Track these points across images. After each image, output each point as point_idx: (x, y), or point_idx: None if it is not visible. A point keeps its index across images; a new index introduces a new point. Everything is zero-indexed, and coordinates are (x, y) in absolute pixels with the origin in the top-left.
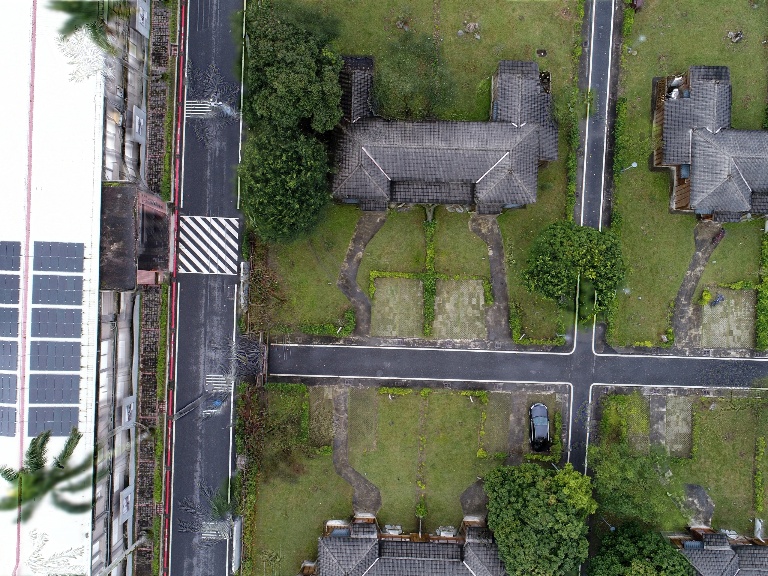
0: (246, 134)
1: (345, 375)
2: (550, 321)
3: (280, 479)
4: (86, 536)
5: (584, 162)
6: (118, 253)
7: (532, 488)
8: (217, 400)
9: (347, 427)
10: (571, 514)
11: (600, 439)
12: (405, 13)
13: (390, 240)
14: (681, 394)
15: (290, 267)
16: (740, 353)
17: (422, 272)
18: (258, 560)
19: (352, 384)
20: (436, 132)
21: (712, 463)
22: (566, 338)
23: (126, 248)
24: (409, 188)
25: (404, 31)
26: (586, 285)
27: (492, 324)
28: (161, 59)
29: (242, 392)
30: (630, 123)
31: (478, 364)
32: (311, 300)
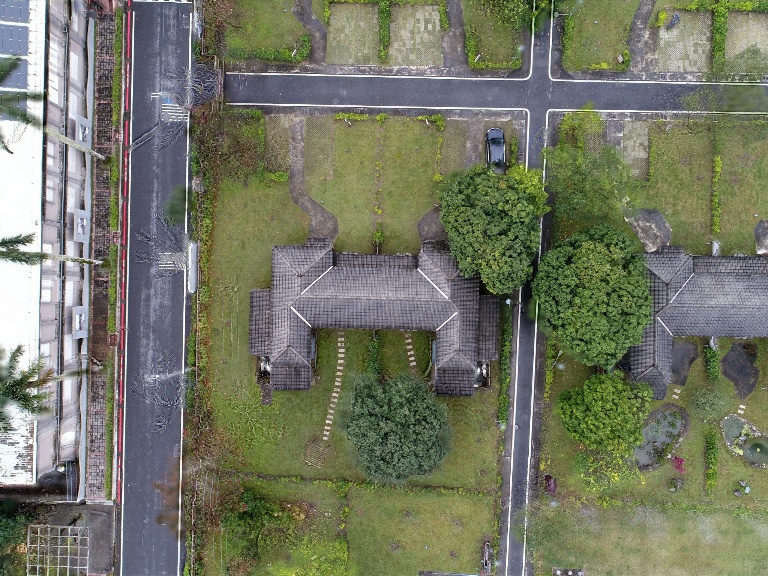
0: None
1: (301, 103)
2: (506, 46)
3: (237, 209)
4: (36, 224)
5: None
6: None
7: (483, 174)
8: (173, 129)
9: (304, 156)
10: (522, 199)
11: (557, 165)
12: None
13: None
14: (638, 119)
15: None
16: (697, 77)
17: None
18: (216, 290)
19: (308, 112)
20: None
21: (669, 188)
22: (522, 64)
23: None
24: None
25: None
26: (542, 10)
27: (448, 50)
28: None
29: (198, 118)
30: None
31: (434, 91)
32: (266, 27)
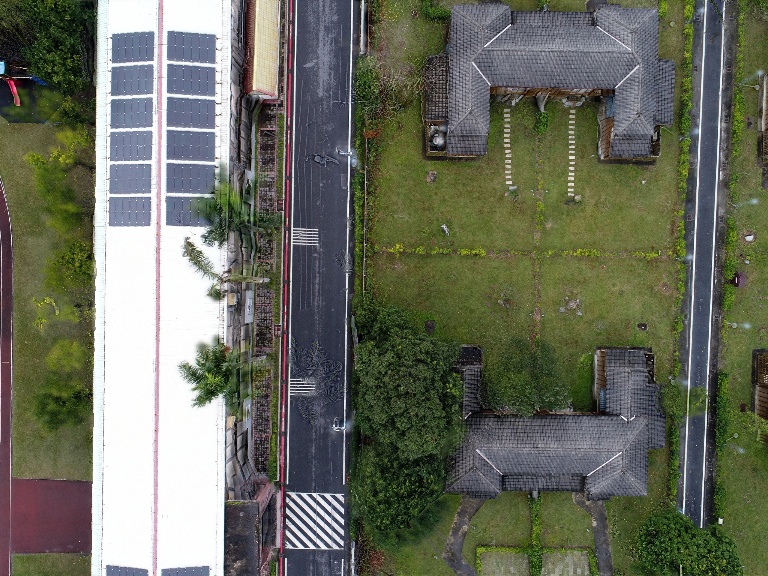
0: (351, 412)
1: None
2: None
3: None
4: None
5: (686, 433)
6: (241, 570)
7: None
8: None
9: None
10: None
11: None
12: (506, 290)
13: (495, 514)
14: None
15: (396, 542)
16: None
17: (528, 547)
18: None
19: None
20: (548, 430)
21: None
22: None
23: (249, 565)
24: (519, 478)
25: (506, 308)
26: None
27: None
28: (265, 339)
29: None
30: (731, 394)
31: None
32: (417, 574)
